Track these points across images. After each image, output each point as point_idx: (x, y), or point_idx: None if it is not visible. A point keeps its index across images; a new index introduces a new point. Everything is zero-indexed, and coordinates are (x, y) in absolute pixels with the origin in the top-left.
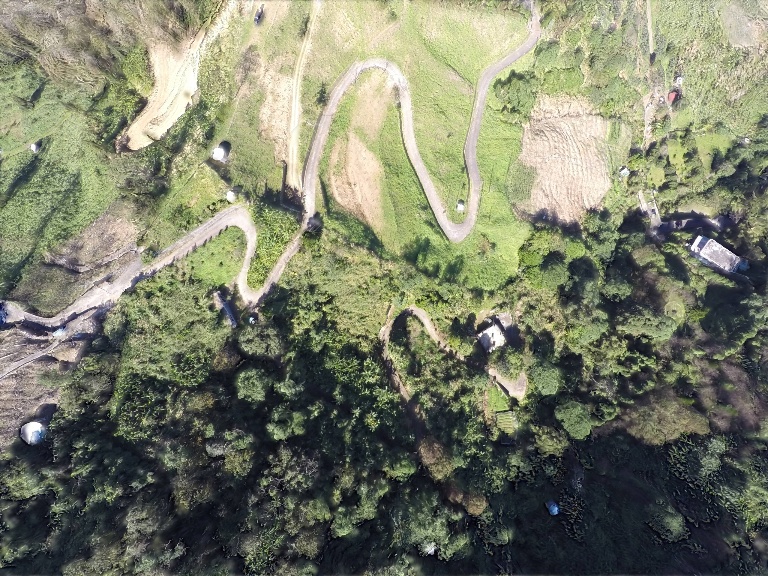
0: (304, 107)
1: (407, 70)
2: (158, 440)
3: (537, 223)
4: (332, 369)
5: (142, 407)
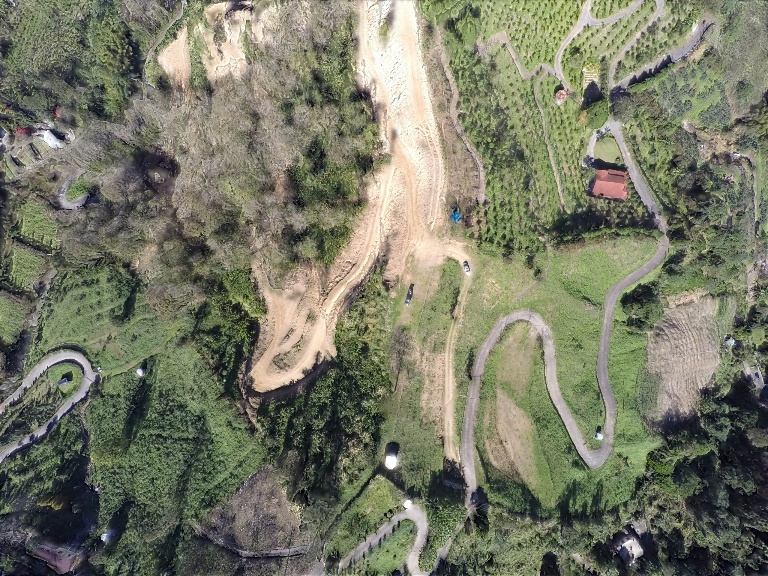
0: (458, 381)
1: (550, 320)
2: None
3: (669, 436)
4: None
5: None
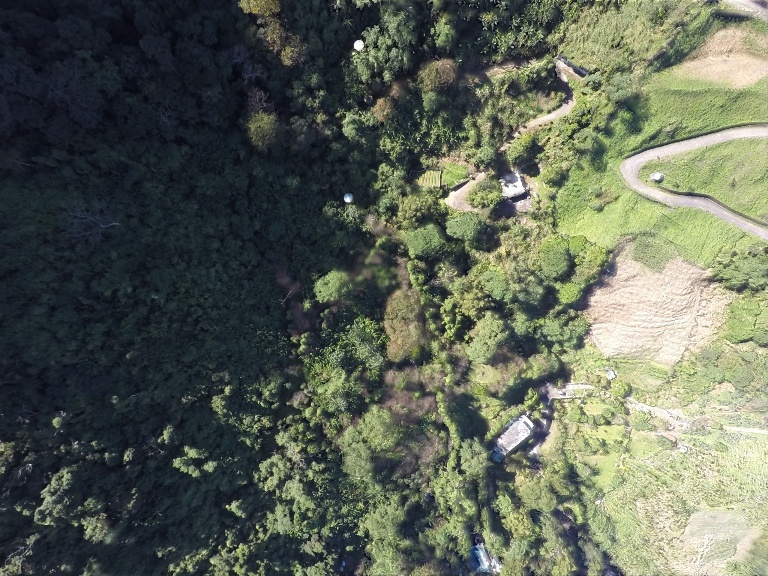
0: None
1: None
2: None
3: None
4: None
5: None
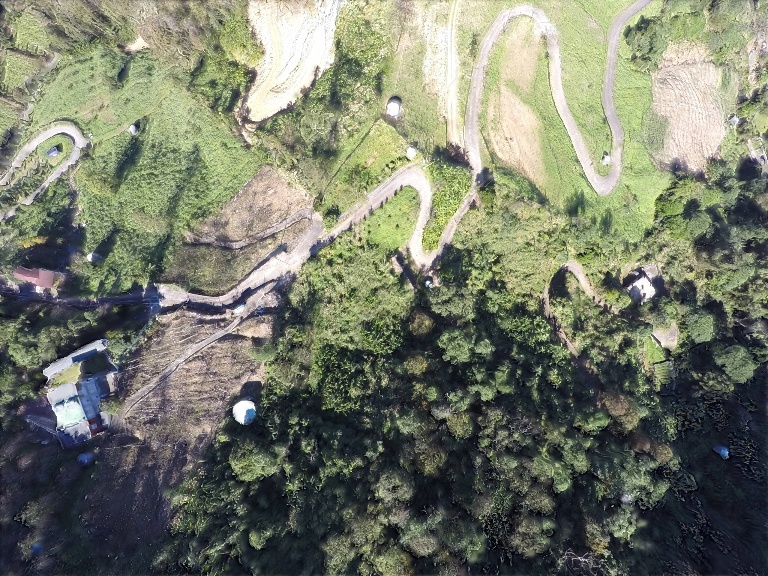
0: (461, 59)
1: (554, 17)
2: (370, 410)
3: (677, 171)
4: (506, 330)
5: (344, 378)
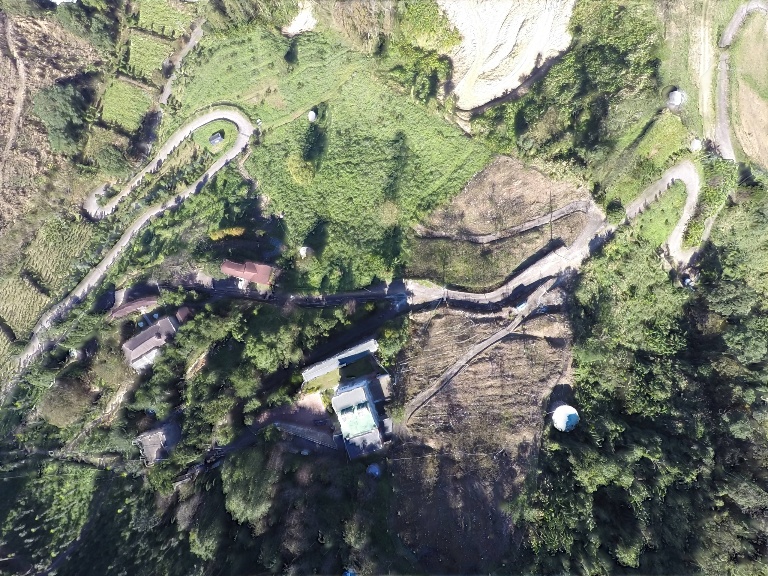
0: None
1: None
2: (677, 414)
3: None
4: None
5: (641, 381)
